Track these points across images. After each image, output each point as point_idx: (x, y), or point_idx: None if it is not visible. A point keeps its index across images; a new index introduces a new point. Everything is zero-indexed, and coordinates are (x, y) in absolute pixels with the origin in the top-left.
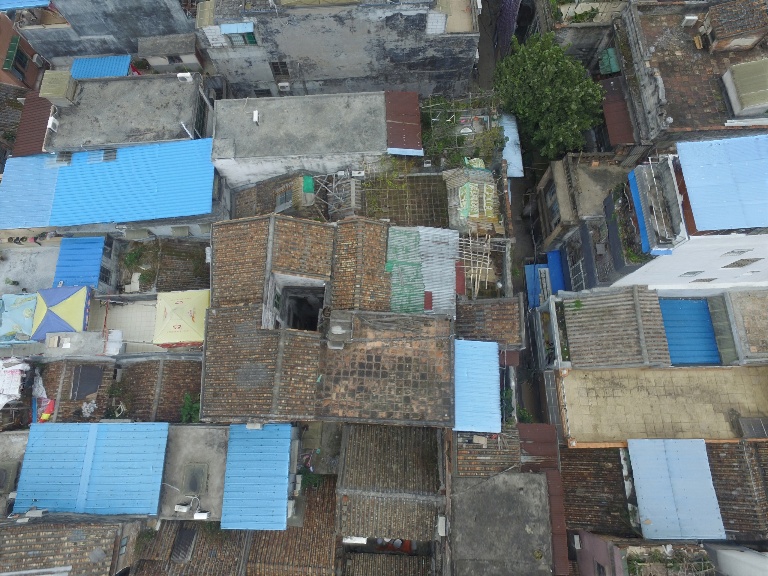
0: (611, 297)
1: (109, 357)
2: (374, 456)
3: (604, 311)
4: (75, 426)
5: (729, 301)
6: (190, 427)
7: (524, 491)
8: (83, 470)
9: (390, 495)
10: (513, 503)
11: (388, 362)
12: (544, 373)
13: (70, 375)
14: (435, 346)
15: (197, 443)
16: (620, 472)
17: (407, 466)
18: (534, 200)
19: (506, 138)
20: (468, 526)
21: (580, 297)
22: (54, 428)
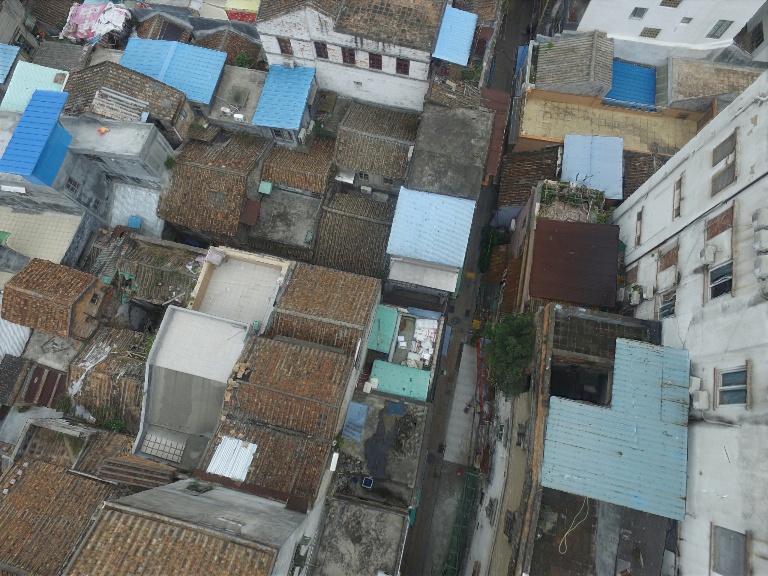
0: (576, 40)
1: (189, 23)
2: (371, 119)
3: (569, 49)
4: (161, 42)
5: (670, 63)
6: (241, 68)
7: (476, 120)
8: (163, 66)
9: (377, 136)
10: (466, 126)
11: (395, 8)
12: (514, 99)
13: (160, 25)
14: (431, 5)
15: (244, 78)
16: (555, 164)
17: (394, 127)
18: (538, 3)
19: None
20: (430, 133)
21: (553, 41)
22: (146, 42)
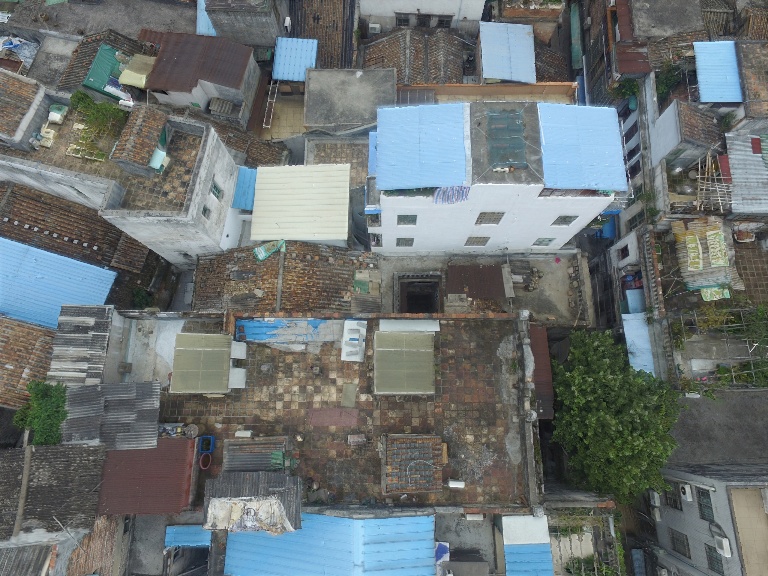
0: None
1: None
2: None
3: None
4: None
5: None
6: None
7: (651, 26)
8: None
9: None
10: (659, 19)
11: None
12: None
13: None
14: (761, 95)
15: None
16: None
17: None
18: None
19: (678, 329)
20: (691, 7)
21: None
22: None
